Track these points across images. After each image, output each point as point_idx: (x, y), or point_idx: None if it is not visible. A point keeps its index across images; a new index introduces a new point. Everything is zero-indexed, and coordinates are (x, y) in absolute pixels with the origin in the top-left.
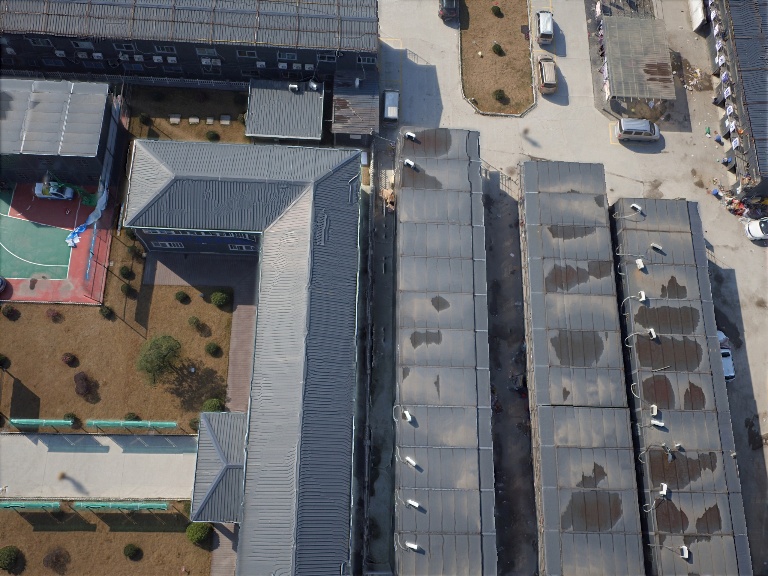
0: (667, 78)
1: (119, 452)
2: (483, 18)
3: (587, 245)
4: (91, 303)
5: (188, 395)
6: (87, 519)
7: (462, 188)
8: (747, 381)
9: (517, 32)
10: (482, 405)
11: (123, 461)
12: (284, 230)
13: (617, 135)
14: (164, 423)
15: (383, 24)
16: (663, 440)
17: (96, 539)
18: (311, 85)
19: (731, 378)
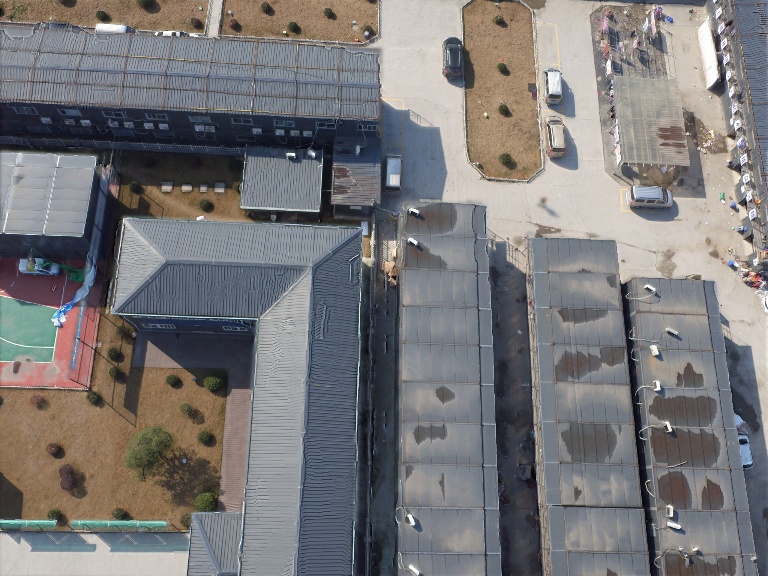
0: (681, 143)
1: (106, 551)
2: (489, 76)
3: (599, 329)
4: (78, 388)
5: (179, 488)
6: None
7: (468, 268)
8: (765, 467)
9: (524, 91)
10: (489, 506)
11: (110, 561)
12: (281, 317)
13: (628, 202)
14: (154, 522)
15: (385, 83)
16: (680, 543)
17: None
18: (310, 153)
19: (749, 466)
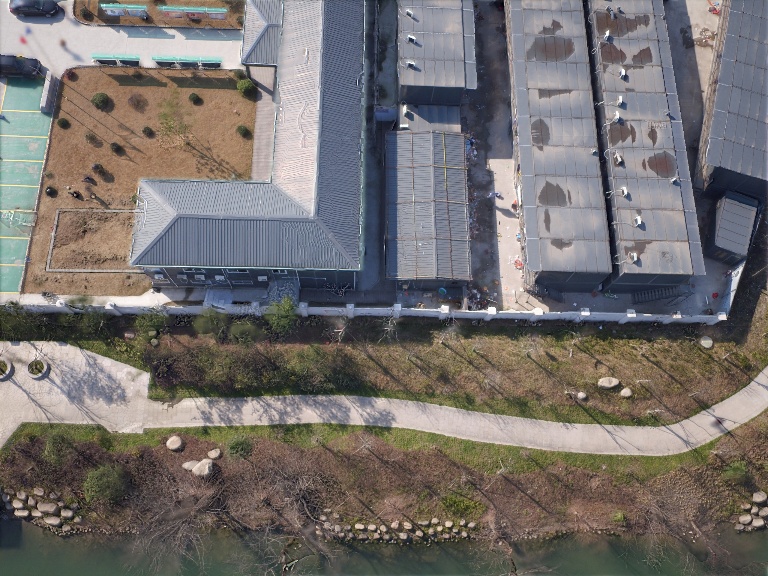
0: None
1: (183, 39)
2: None
3: None
4: None
5: (235, 3)
6: (160, 80)
7: None
8: (682, 3)
9: None
10: None
11: (186, 45)
12: None
13: None
14: (218, 10)
15: None
16: None
17: (167, 92)
18: None
19: None
